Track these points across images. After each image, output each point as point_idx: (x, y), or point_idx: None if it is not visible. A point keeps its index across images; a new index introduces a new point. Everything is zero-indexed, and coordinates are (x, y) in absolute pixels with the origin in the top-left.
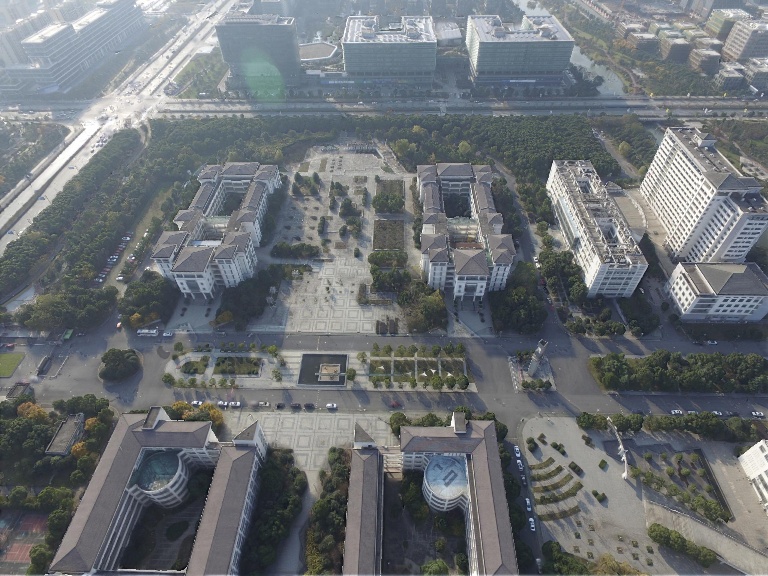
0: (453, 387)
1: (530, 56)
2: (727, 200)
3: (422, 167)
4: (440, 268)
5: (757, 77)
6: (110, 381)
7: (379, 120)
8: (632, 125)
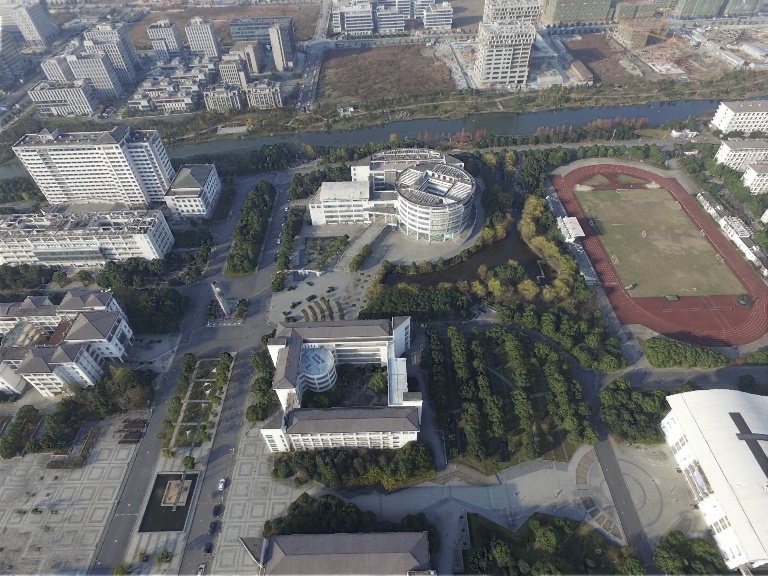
0: None
1: None
2: (129, 146)
3: None
4: (83, 358)
5: None
6: None
7: None
8: None
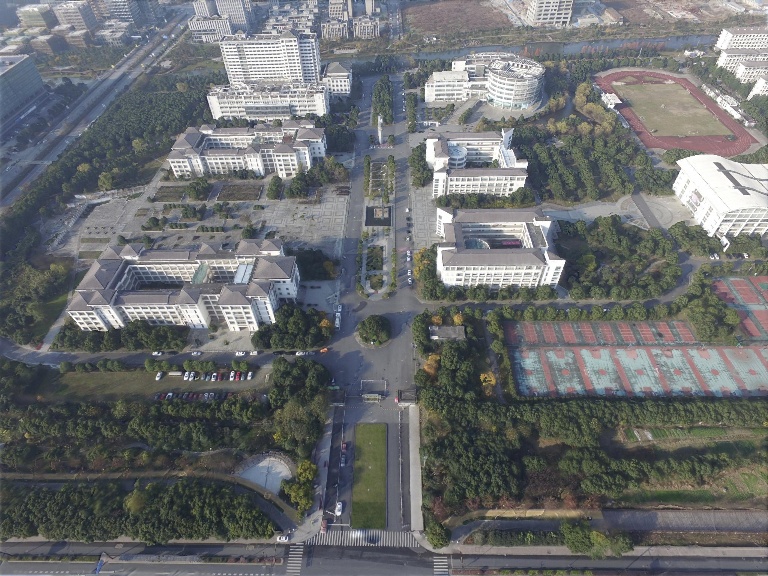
0: None
1: (14, 86)
2: (301, 41)
3: (174, 155)
4: None
5: (129, 30)
6: (391, 334)
7: (39, 193)
8: (156, 78)
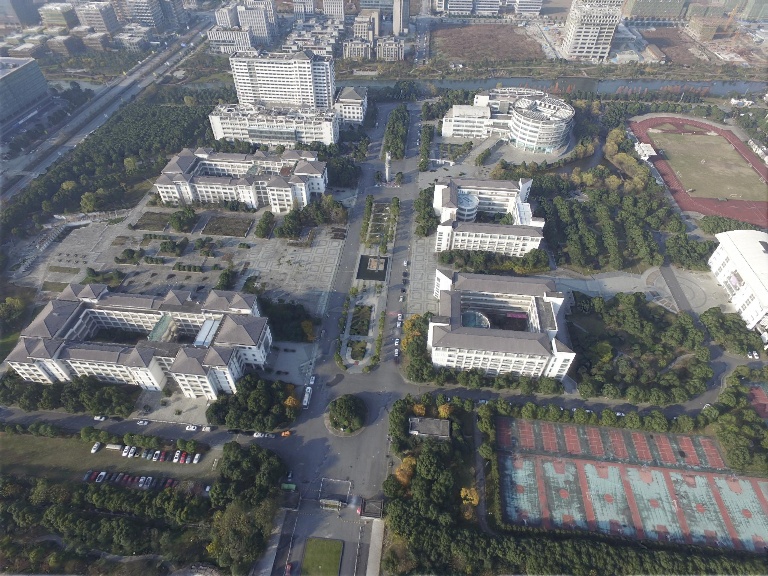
0: None
1: (15, 90)
2: (315, 63)
3: (162, 180)
4: (306, 185)
5: (148, 35)
6: (365, 420)
7: (15, 211)
8: (165, 89)
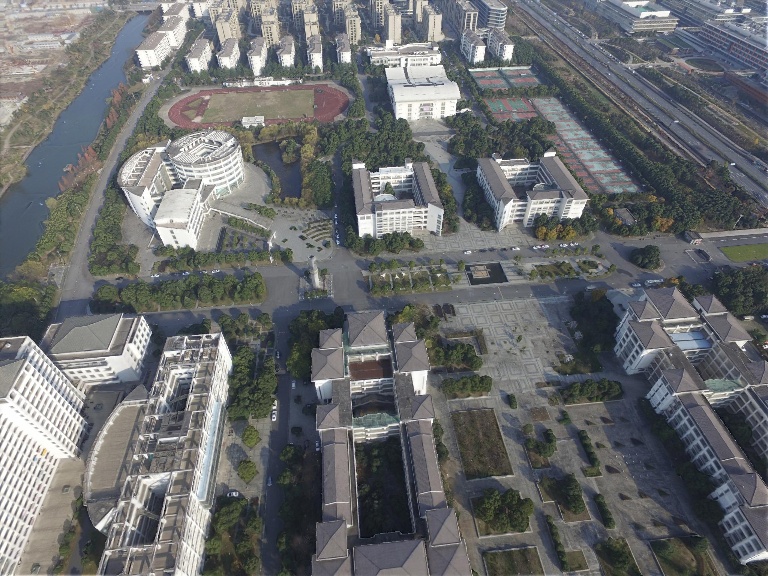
0: (380, 272)
1: None
2: None
3: (462, 572)
4: None
5: None
6: None
7: None
8: None
